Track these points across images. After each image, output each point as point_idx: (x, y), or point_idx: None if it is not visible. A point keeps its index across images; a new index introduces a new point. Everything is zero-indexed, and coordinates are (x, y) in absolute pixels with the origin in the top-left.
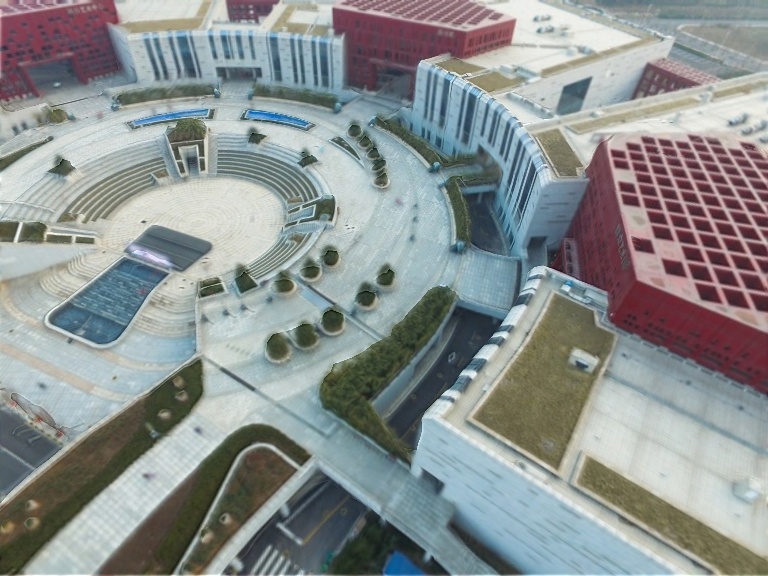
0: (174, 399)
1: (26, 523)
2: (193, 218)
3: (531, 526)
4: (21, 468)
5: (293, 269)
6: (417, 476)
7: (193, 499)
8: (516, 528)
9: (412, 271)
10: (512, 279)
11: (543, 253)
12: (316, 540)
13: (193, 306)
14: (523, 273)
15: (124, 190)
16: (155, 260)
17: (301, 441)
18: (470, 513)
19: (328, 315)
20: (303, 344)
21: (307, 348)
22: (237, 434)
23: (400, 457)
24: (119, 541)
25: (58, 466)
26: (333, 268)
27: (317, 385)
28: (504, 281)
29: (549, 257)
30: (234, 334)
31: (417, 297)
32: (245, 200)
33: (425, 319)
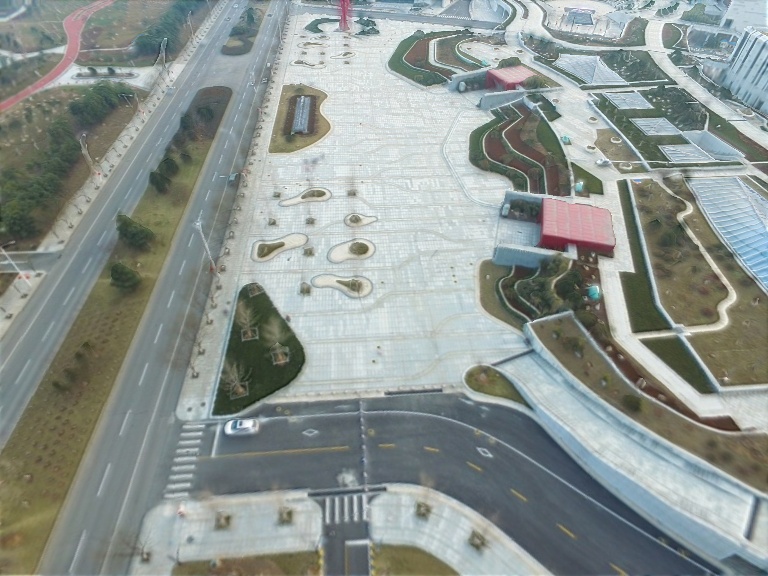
0: (643, 19)
1: (639, 26)
2: (576, 6)
3: (765, 13)
4: (603, 39)
5: (639, 7)
6: (722, 26)
7: (671, 26)
8: (759, 19)
9: (680, 7)
10: (716, 8)
11: (722, 3)
12: (696, 45)
13: (609, 19)
14: (718, 7)
15: (541, 0)
16: (582, 11)
17: (685, 24)
18: (741, 27)
19: (670, 7)
20: (665, 14)
21: (667, 15)
22: (667, 23)
23: (715, 24)
24: (661, 29)
25: (630, 24)
26: (653, 6)
27: (678, 19)
28: (713, 8)
29: (725, 4)
30: (640, 15)
31: (688, 10)
32: (588, 3)
33: (702, 6)
